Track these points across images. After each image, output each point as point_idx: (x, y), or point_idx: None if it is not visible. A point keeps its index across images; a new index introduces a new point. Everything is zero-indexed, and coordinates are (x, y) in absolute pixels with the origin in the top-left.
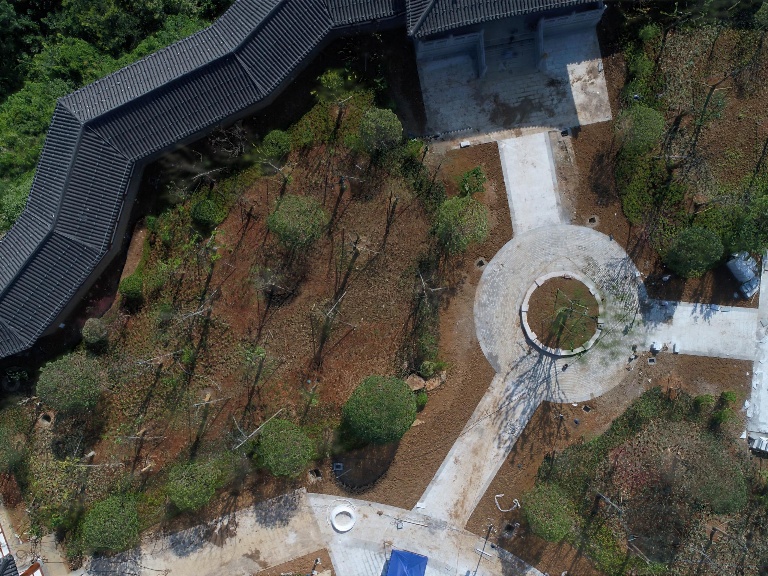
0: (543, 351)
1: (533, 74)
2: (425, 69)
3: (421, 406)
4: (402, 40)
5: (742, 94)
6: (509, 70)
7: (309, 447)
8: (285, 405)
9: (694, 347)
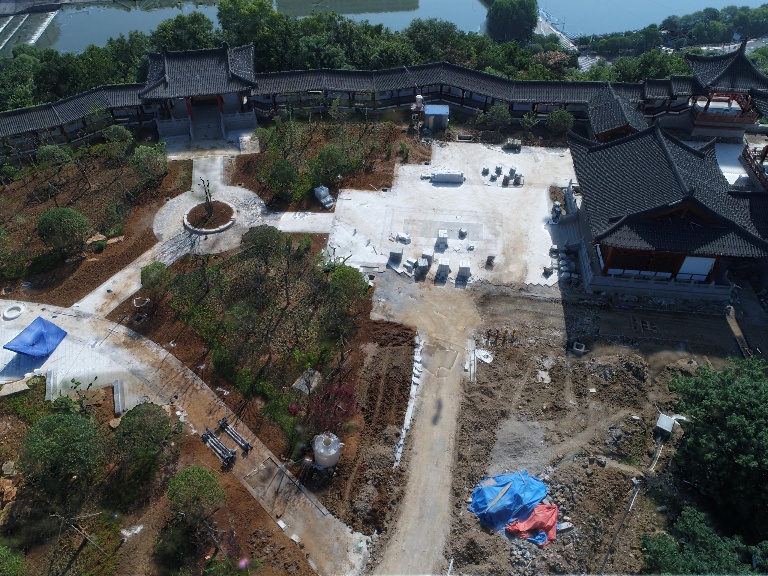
0: (193, 232)
1: (220, 140)
2: (163, 139)
3: (100, 252)
4: (155, 131)
5: (328, 141)
6: (208, 139)
7: (3, 234)
8: (6, 249)
9: (292, 229)
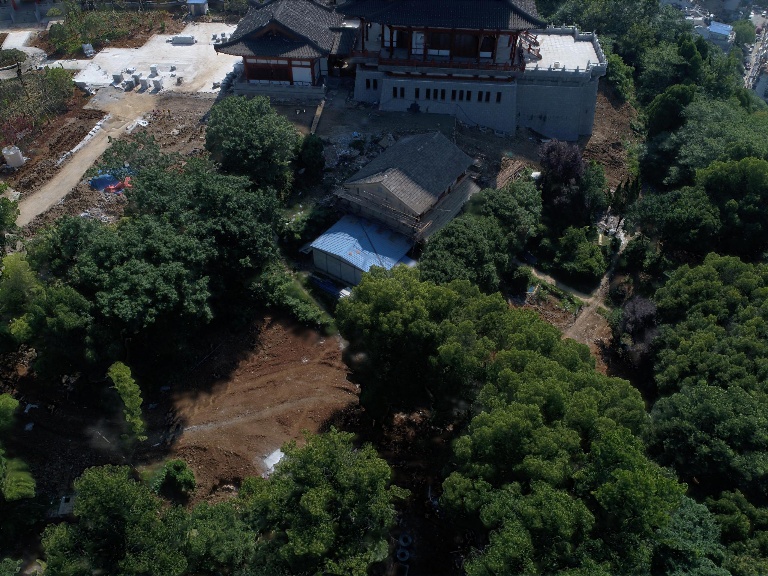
0: None
1: None
2: None
3: None
4: None
5: None
6: None
7: None
8: None
9: None
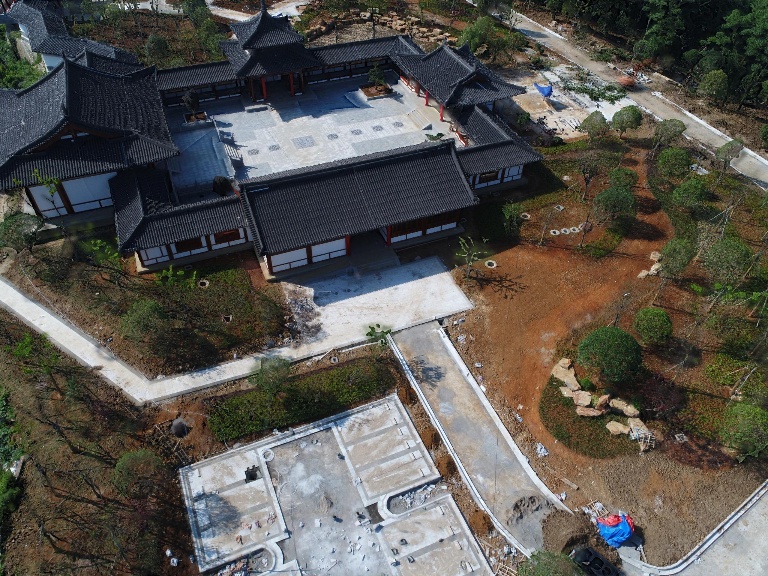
0: None
1: None
2: None
3: None
4: None
5: None
6: None
7: None
8: None
9: None
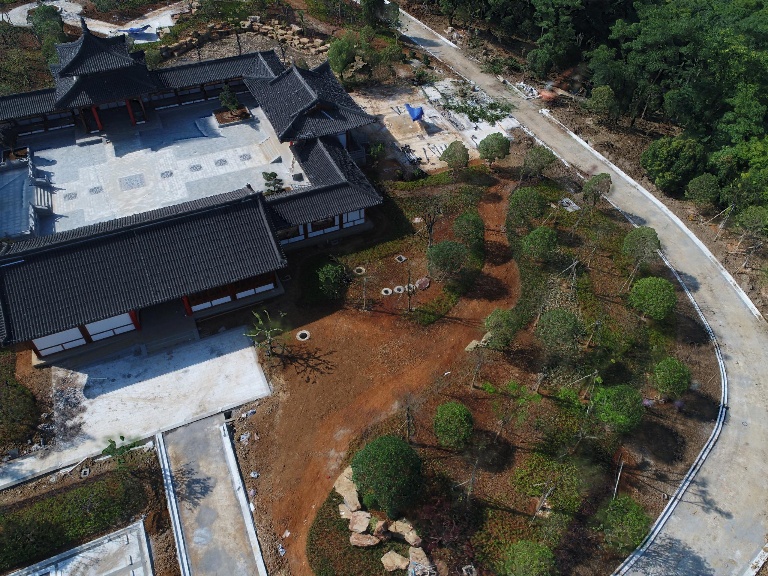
0: None
1: None
2: None
3: None
4: None
5: None
6: None
7: None
8: None
9: None
